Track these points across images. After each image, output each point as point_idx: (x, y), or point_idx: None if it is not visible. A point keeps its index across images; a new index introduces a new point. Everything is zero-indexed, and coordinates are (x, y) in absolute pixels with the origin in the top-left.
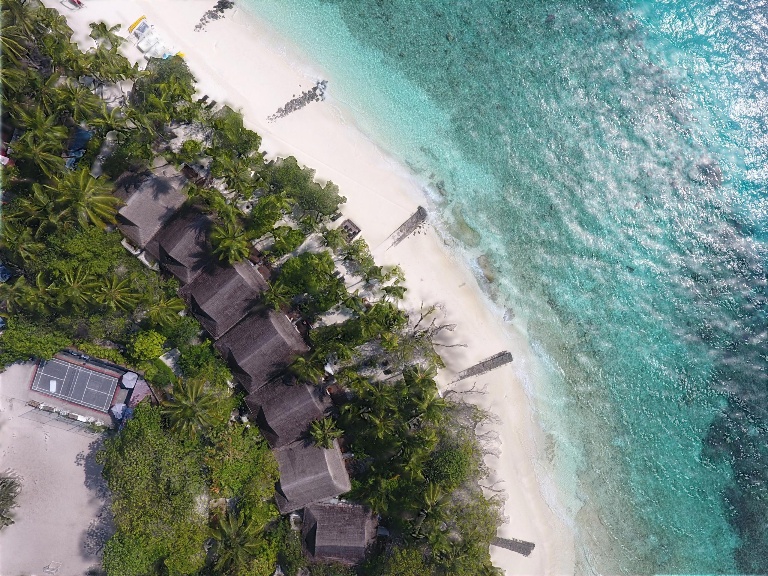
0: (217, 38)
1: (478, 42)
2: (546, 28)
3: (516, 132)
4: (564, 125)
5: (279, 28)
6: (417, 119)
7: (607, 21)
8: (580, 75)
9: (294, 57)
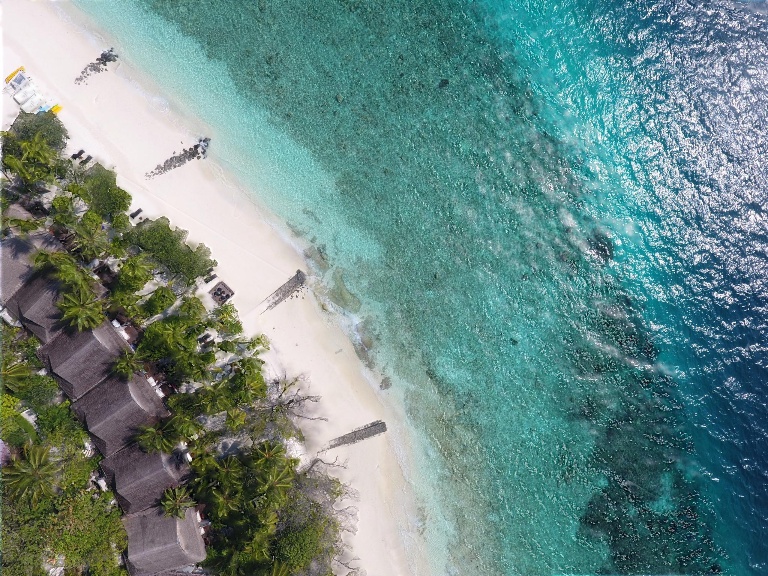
0: (98, 91)
1: (368, 104)
2: (440, 93)
3: (403, 197)
4: (453, 192)
5: (164, 83)
6: (302, 180)
7: (503, 88)
8: (472, 142)
9: (177, 113)
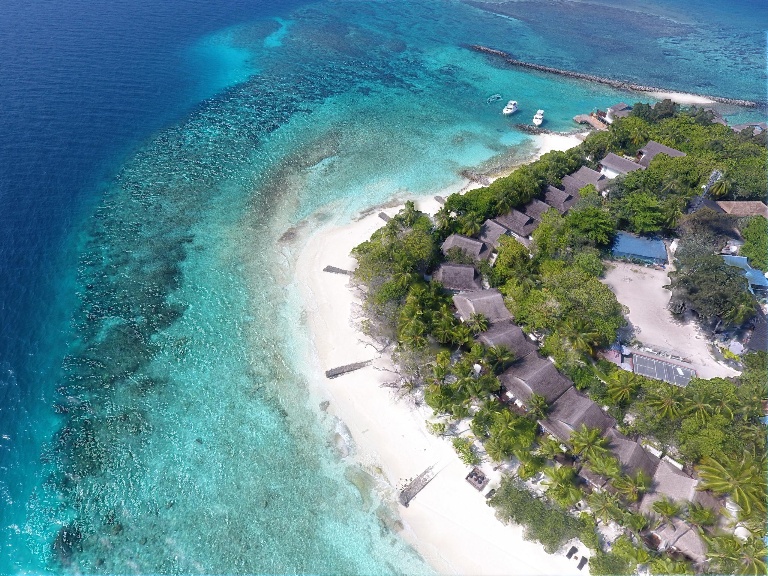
0: None
1: None
2: None
3: None
4: None
5: None
6: None
7: None
8: None
9: None
